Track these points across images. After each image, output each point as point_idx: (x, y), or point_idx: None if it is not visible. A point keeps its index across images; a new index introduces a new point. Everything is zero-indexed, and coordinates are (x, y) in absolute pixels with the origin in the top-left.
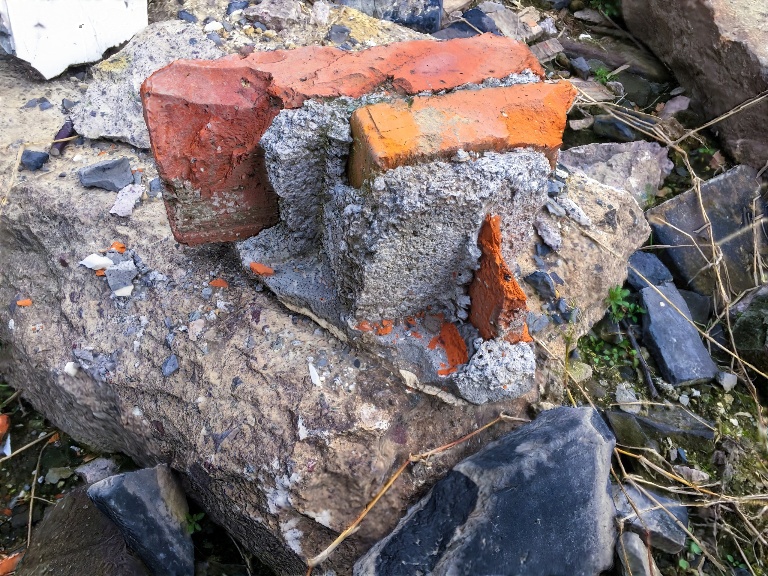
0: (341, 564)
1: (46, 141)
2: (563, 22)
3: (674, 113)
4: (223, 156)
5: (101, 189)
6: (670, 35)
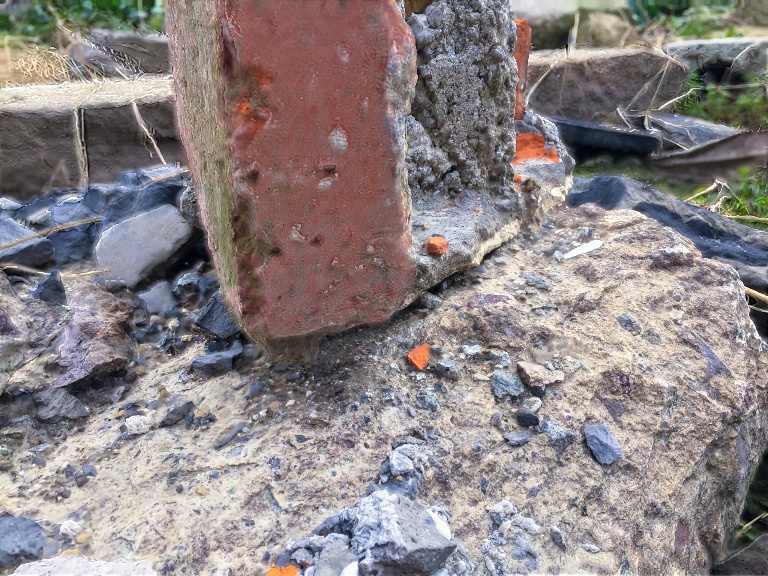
0: None
1: None
2: None
3: None
4: None
5: None
6: None
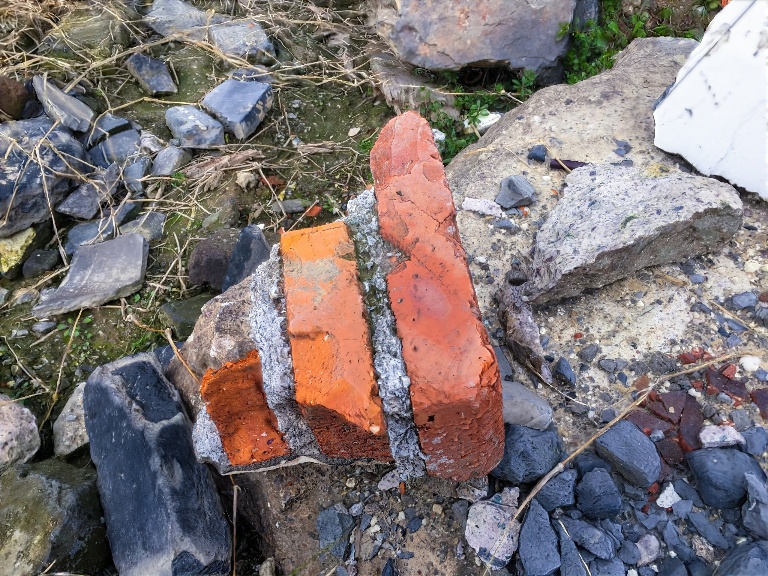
0: None
1: (568, 158)
2: None
3: None
4: None
5: None
6: None
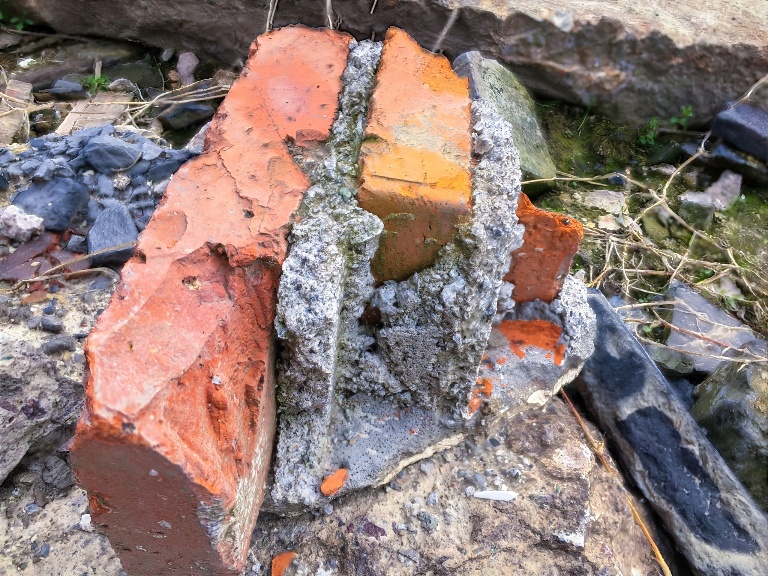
0: None
1: None
2: None
3: (194, 72)
4: (239, 404)
5: None
6: (120, 8)
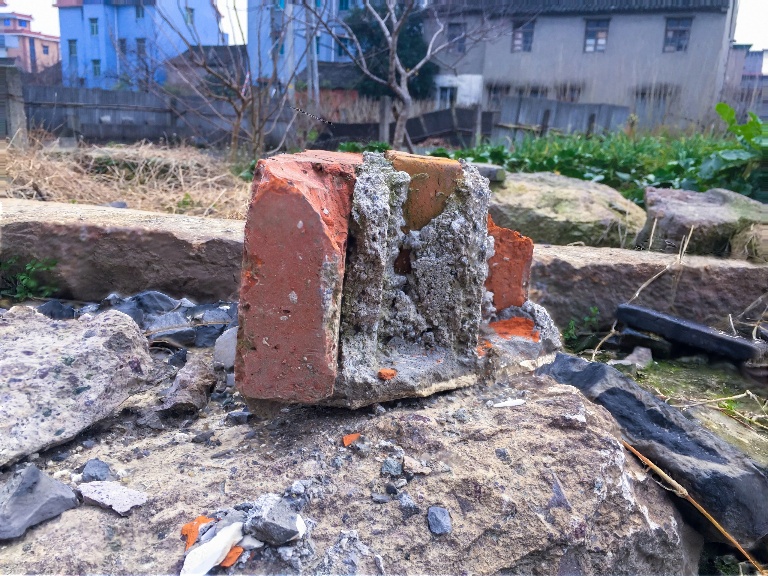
0: (664, 508)
1: None
2: None
3: None
4: None
5: (39, 527)
6: (135, 273)
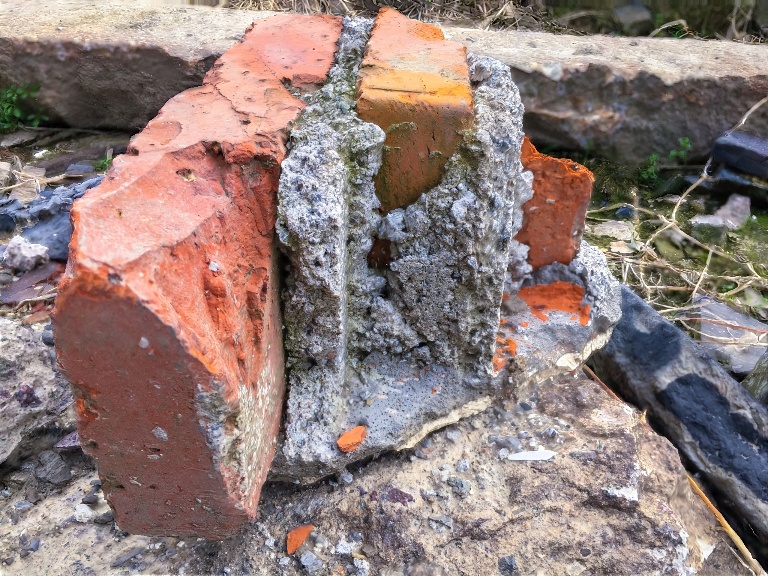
0: (734, 571)
1: None
2: (3, 156)
3: None
4: (240, 310)
5: None
6: (130, 97)
